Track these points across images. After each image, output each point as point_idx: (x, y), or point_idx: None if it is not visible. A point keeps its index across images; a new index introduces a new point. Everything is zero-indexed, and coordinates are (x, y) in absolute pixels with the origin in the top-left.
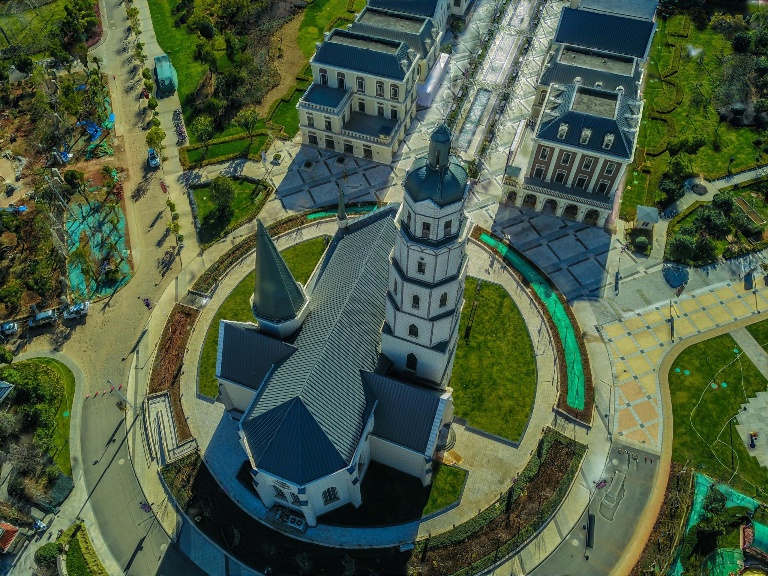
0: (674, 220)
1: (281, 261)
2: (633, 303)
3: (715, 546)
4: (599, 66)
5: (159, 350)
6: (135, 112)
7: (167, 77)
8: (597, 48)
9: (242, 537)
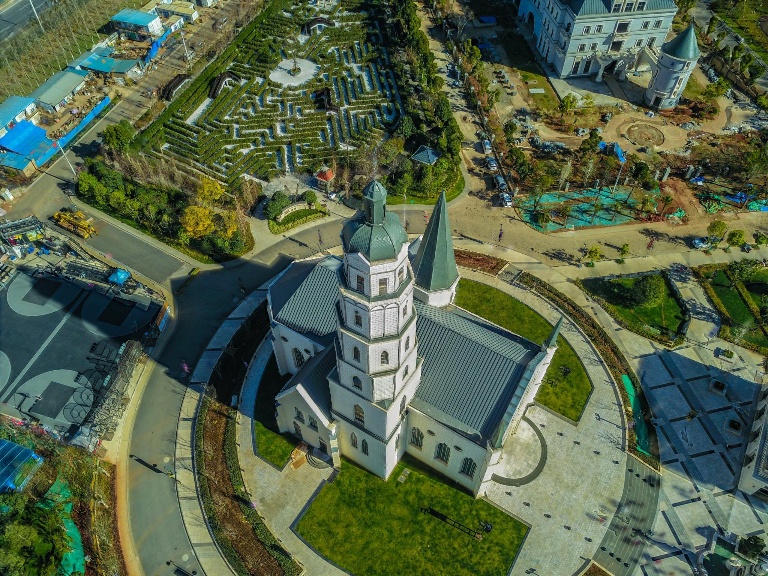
0: None
1: (435, 239)
2: None
3: None
4: None
5: (459, 250)
6: None
7: None
8: None
9: None
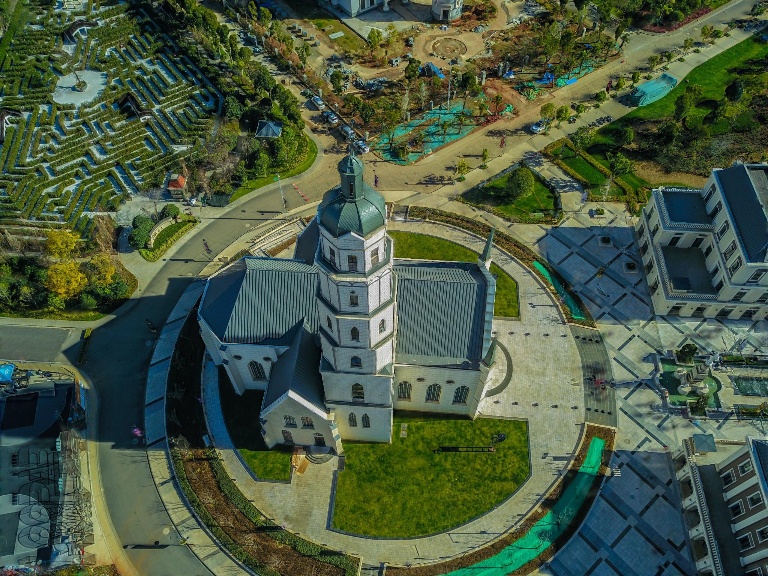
0: None
1: None
2: None
3: None
4: None
5: None
6: (589, 92)
7: (644, 91)
8: None
9: None
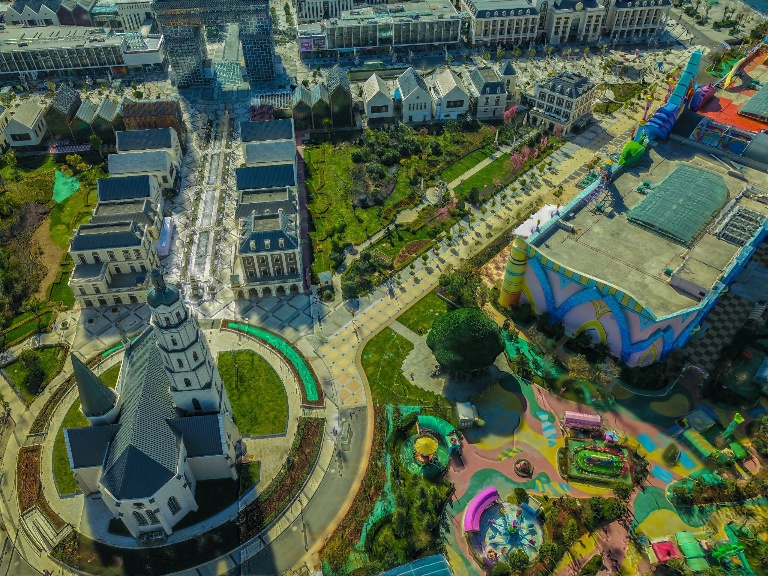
0: (343, 274)
1: (93, 374)
2: (332, 330)
3: (405, 438)
4: (267, 199)
5: (19, 482)
6: None
7: None
8: (265, 187)
9: (125, 563)
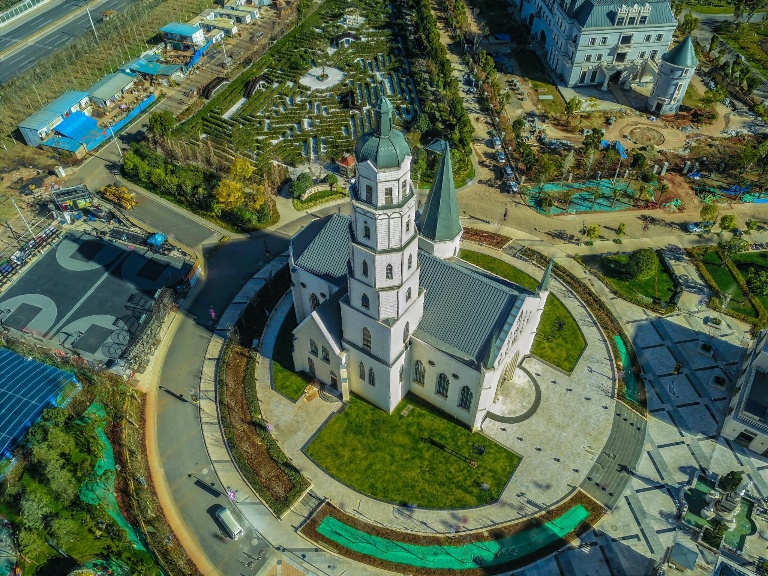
0: None
1: (440, 190)
2: None
3: None
4: None
5: (467, 228)
6: None
7: None
8: None
9: None
